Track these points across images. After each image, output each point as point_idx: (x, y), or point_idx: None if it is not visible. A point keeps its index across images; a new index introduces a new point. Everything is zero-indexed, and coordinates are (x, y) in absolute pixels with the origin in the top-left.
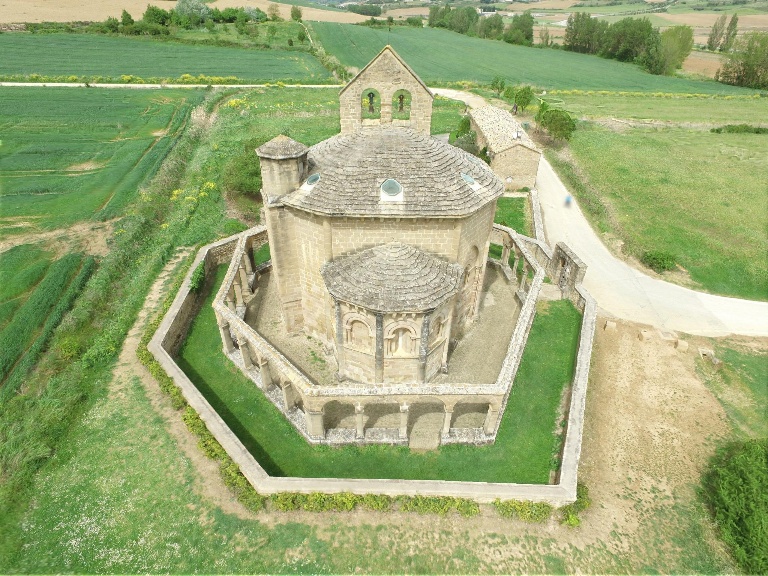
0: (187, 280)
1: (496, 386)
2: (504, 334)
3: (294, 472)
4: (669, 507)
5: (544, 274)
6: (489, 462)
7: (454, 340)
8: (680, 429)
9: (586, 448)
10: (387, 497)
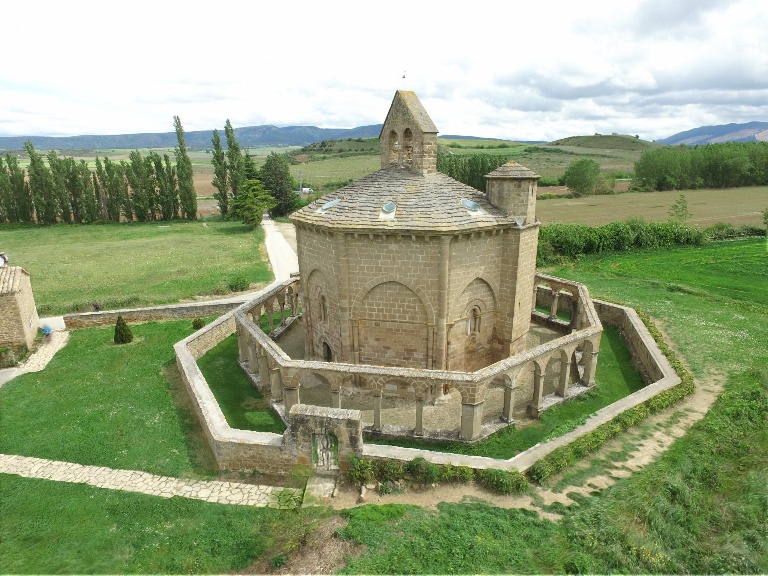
0: (592, 424)
1: None
2: None
3: None
4: None
5: None
6: None
7: None
8: None
9: None
10: None
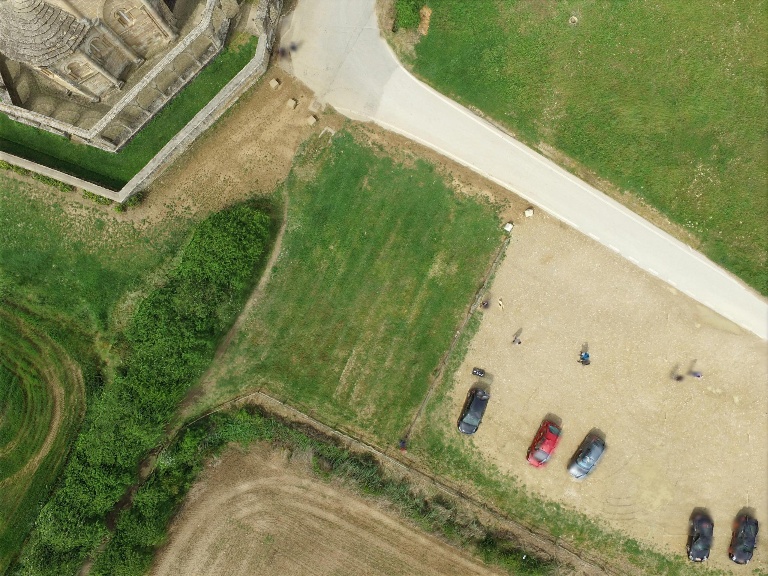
0: None
1: (84, 133)
2: (187, 64)
3: (2, 133)
4: (186, 218)
5: (204, 28)
6: (111, 163)
7: (137, 61)
8: (241, 181)
9: (171, 174)
10: (26, 170)
